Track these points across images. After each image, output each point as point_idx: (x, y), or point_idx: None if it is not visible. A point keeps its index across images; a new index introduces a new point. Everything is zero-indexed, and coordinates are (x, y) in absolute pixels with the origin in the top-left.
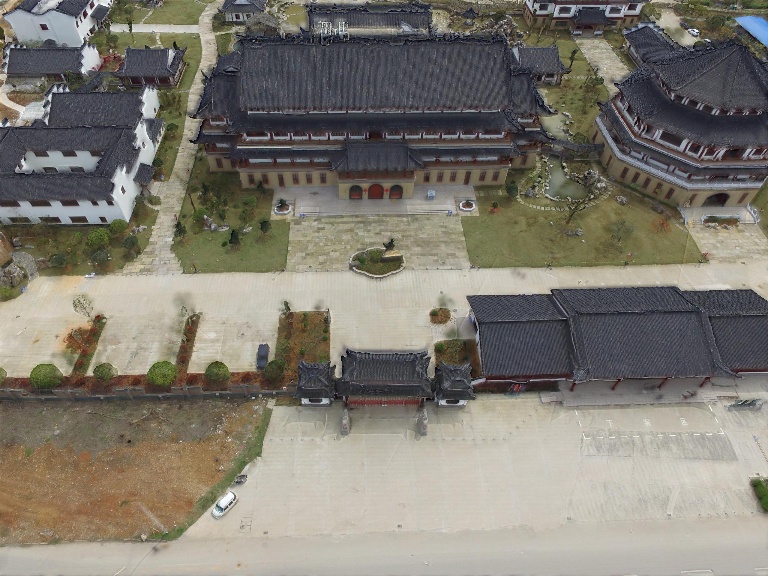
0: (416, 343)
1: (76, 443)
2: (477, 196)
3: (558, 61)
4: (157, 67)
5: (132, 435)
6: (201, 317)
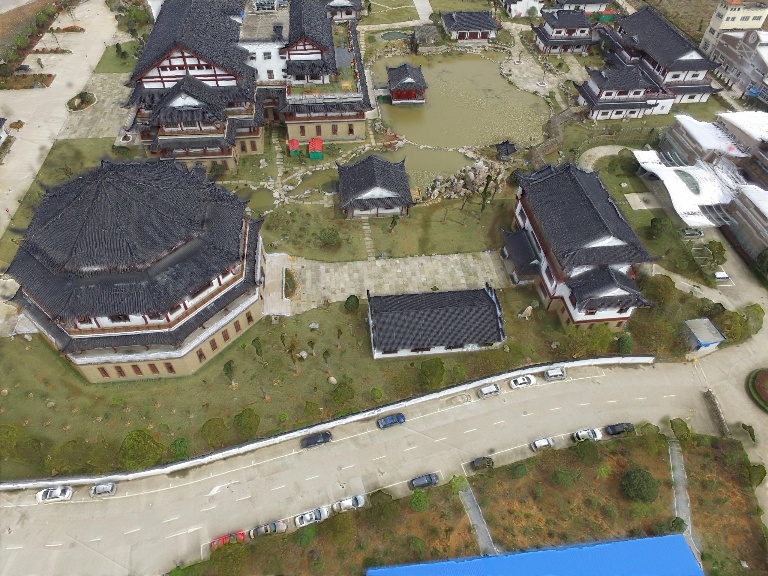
0: (1, 116)
1: (8, 37)
2: (140, 146)
3: (358, 194)
4: (327, 2)
5: (2, 47)
6: (68, 54)
